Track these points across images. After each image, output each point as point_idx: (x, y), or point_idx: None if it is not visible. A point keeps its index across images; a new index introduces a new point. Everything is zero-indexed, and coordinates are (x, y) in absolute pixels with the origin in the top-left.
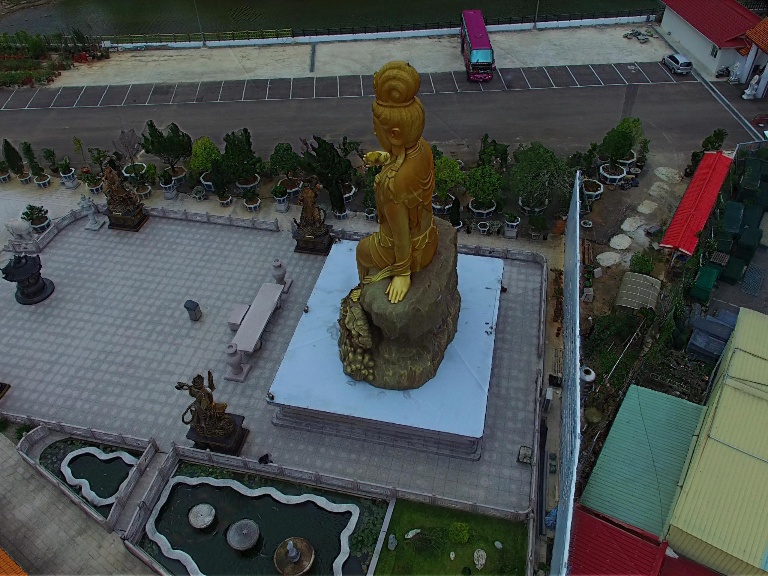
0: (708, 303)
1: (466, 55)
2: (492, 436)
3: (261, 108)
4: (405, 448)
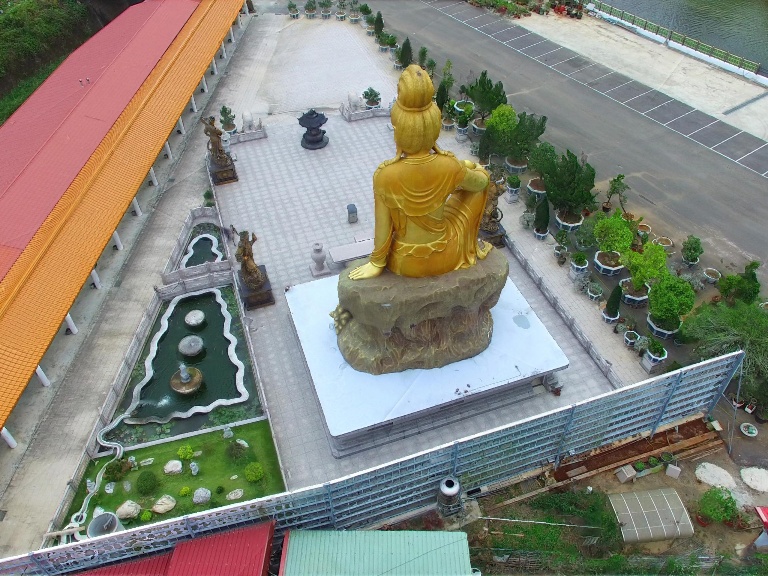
0: None
1: None
2: (369, 458)
3: (626, 118)
4: None
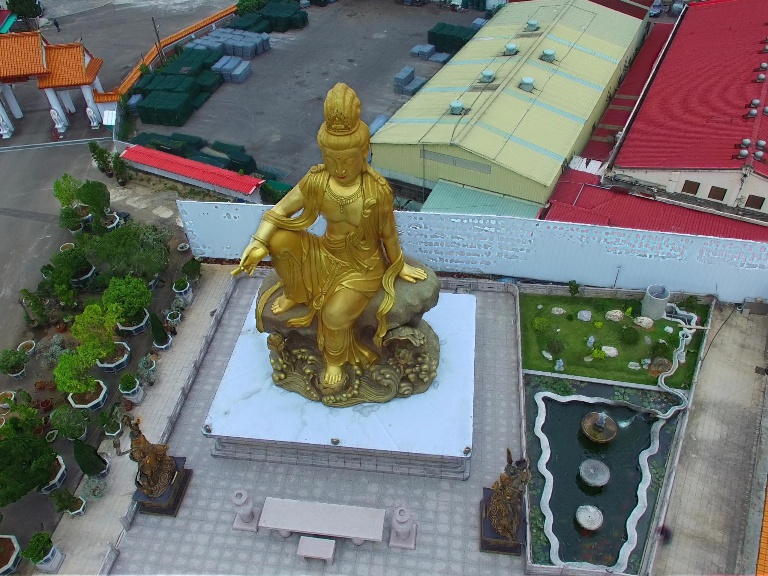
0: None
1: None
2: None
3: None
4: None
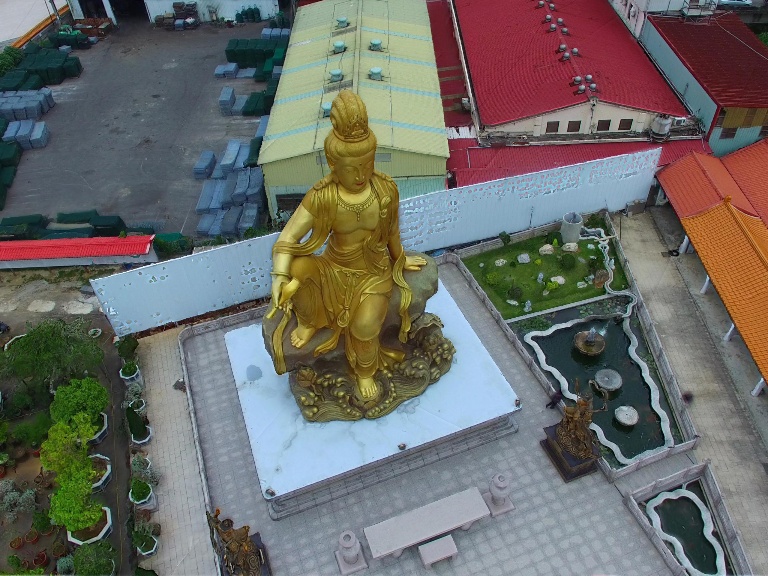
0: None
1: None
2: None
3: None
4: None
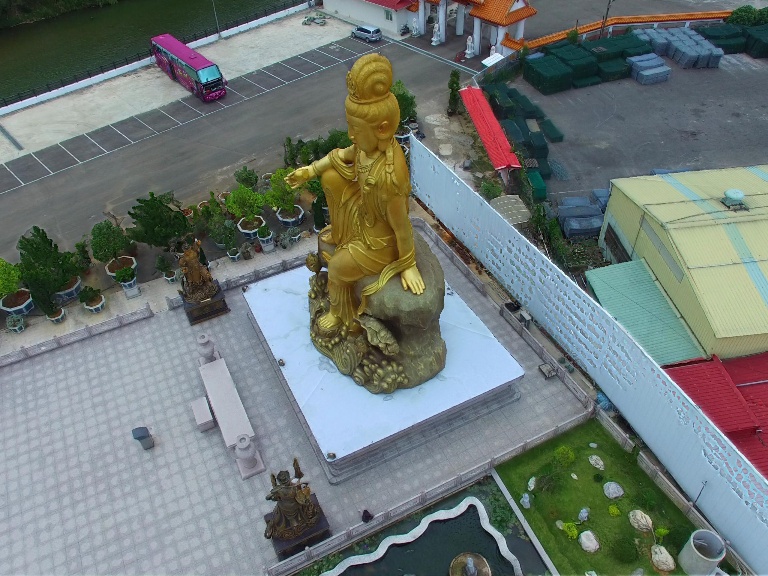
0: (547, 199)
1: (186, 79)
2: None
3: None
4: (462, 426)
